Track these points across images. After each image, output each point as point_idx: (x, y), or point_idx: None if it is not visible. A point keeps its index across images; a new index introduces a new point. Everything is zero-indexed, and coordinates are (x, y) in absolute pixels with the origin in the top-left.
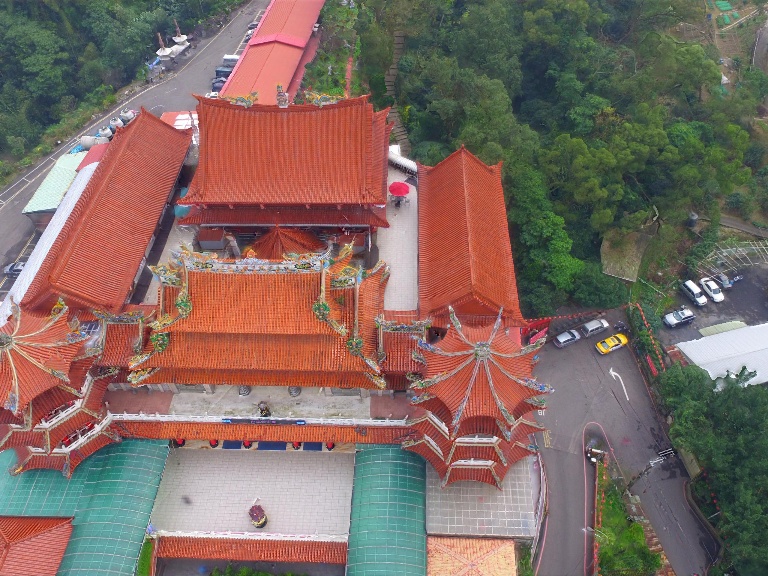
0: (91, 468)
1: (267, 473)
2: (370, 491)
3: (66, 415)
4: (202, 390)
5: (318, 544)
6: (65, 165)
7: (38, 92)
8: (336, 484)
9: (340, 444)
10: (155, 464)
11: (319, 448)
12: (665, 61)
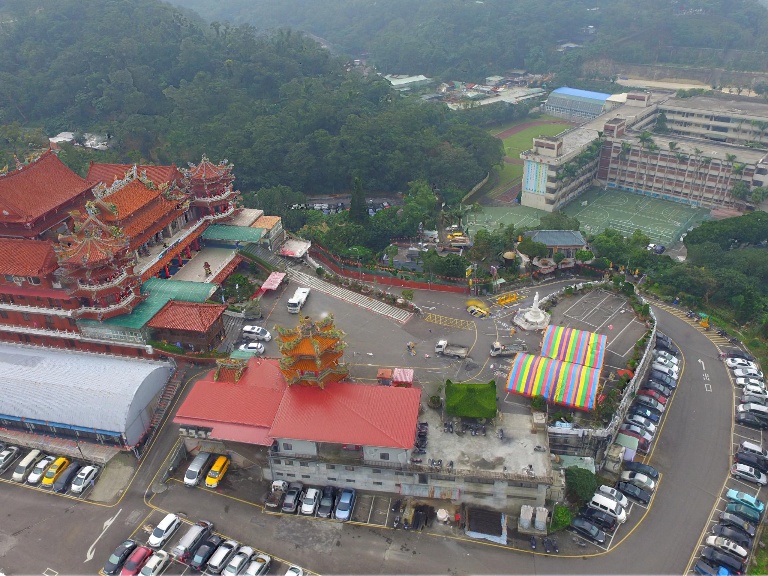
0: None
1: (188, 273)
2: (223, 232)
3: None
4: (136, 264)
5: (230, 263)
6: None
7: None
8: (208, 258)
9: (191, 256)
10: None
11: (188, 261)
12: (71, 151)
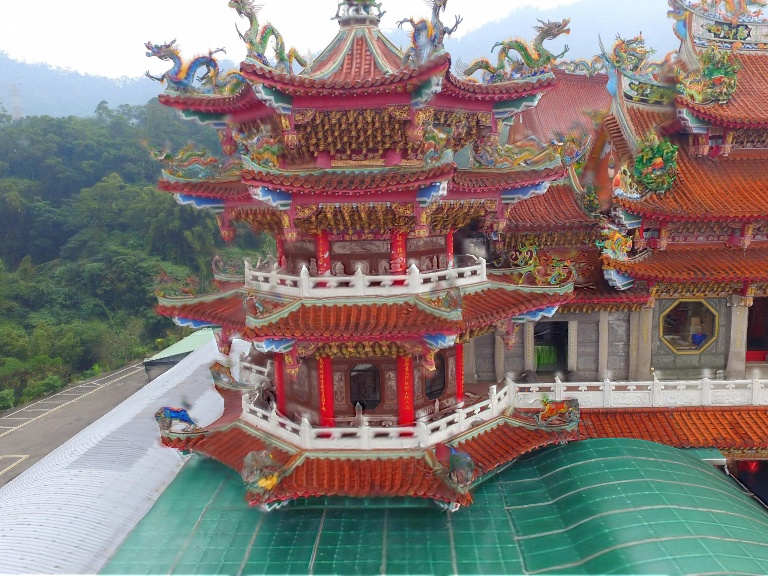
0: (510, 505)
1: None
2: None
3: (458, 284)
4: (713, 369)
5: None
6: (204, 333)
7: (157, 317)
8: None
9: None
10: (736, 491)
11: None
12: None
